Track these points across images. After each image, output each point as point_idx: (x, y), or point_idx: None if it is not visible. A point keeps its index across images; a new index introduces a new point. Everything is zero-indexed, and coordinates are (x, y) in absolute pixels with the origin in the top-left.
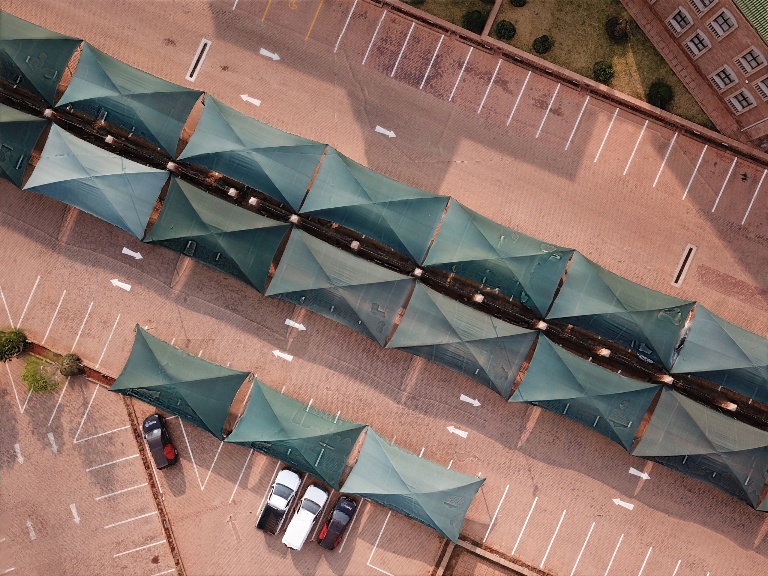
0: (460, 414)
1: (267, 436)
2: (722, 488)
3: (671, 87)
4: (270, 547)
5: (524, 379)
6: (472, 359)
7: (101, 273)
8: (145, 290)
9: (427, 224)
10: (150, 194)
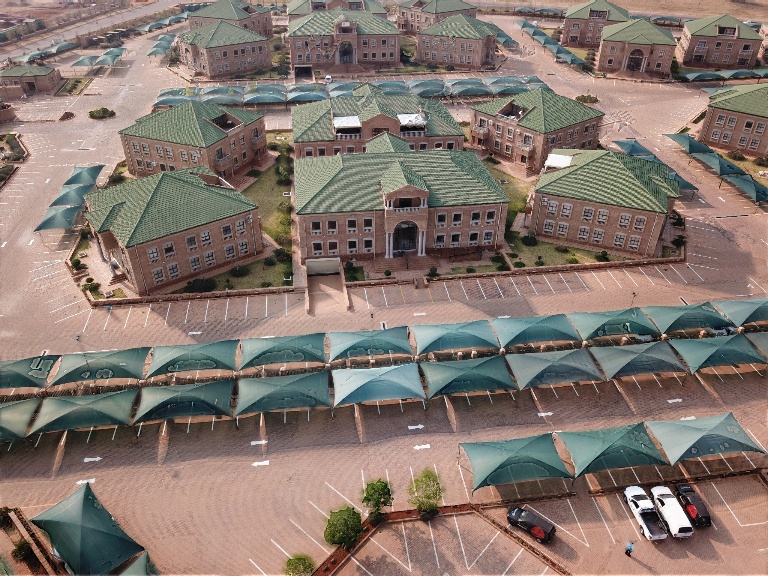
0: (678, 410)
1: (599, 450)
2: None
3: None
4: (673, 559)
5: (686, 361)
6: (654, 359)
7: (404, 447)
8: (440, 442)
9: (567, 325)
10: (414, 375)
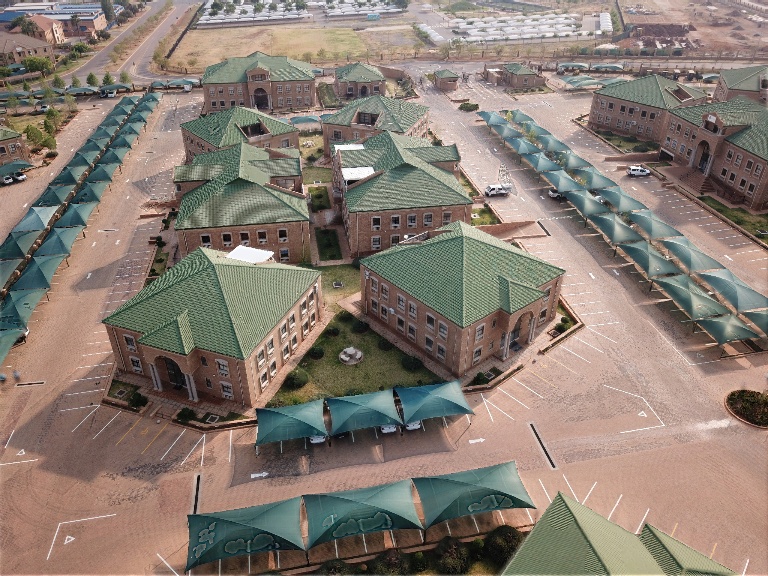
0: None
1: None
2: None
3: None
4: None
5: None
6: None
7: None
8: None
9: (32, 285)
10: (34, 228)
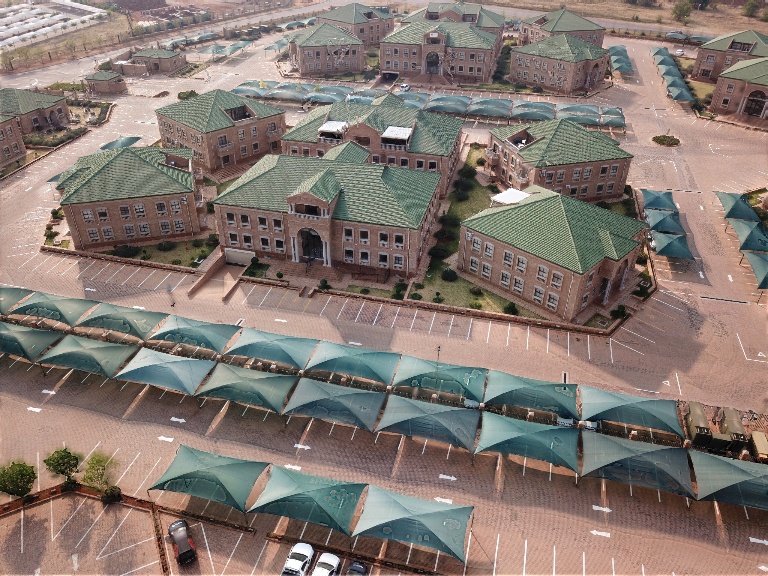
0: (442, 488)
1: (286, 494)
2: (661, 487)
3: (515, 308)
4: None
5: (481, 438)
6: (438, 424)
7: (151, 434)
8: (184, 440)
9: (390, 366)
10: (202, 372)
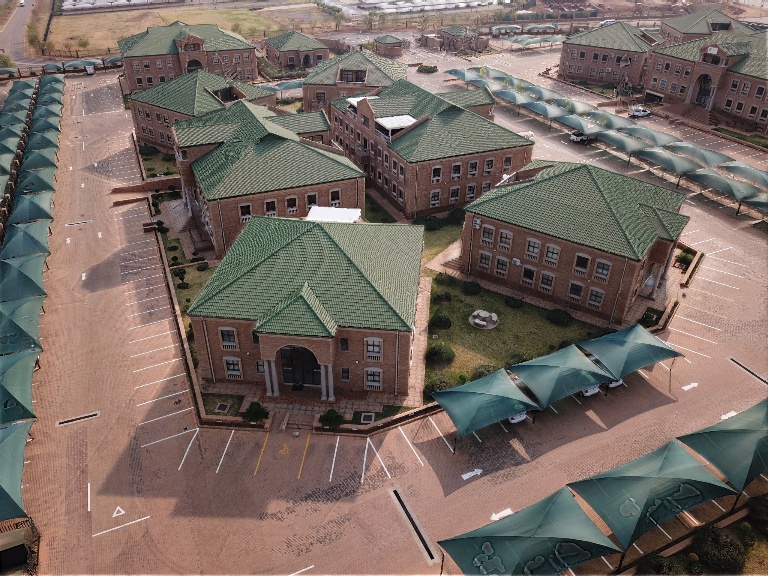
0: None
1: None
2: None
3: None
4: None
5: None
6: None
7: None
8: None
9: (19, 293)
10: None
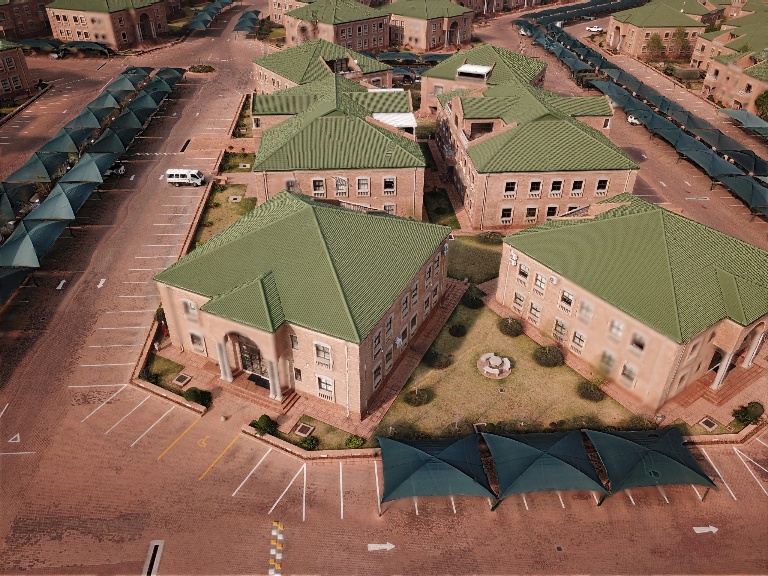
0: None
1: None
2: None
3: None
4: None
5: None
6: None
7: None
8: None
9: None
10: None
